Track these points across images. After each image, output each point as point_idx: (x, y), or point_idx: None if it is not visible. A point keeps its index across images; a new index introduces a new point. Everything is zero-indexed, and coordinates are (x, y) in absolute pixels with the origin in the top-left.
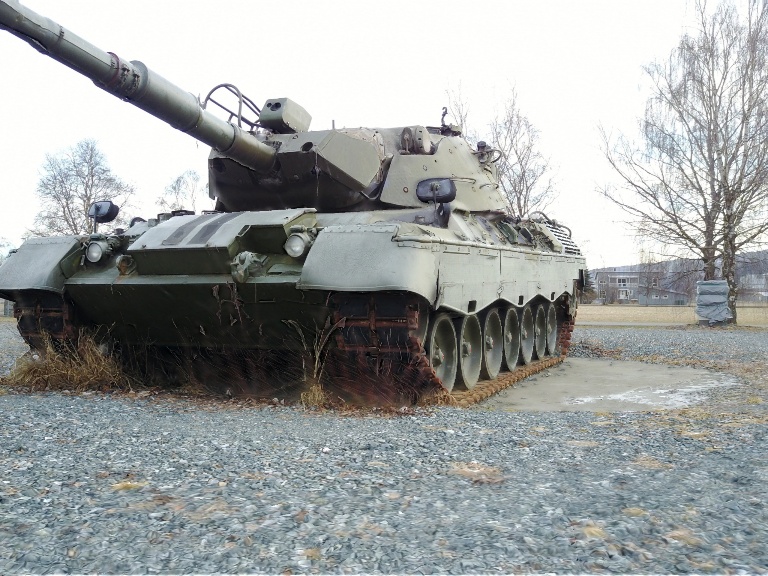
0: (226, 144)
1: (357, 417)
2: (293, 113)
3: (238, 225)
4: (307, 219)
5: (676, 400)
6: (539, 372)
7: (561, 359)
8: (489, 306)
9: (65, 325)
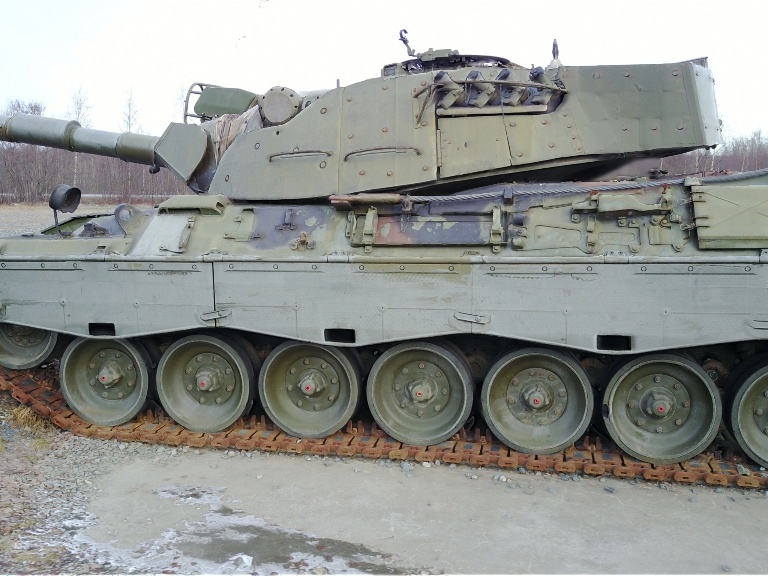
0: (115, 154)
1: None
2: (214, 101)
3: None
4: (81, 224)
5: (192, 562)
6: (535, 472)
7: None
8: None
9: None
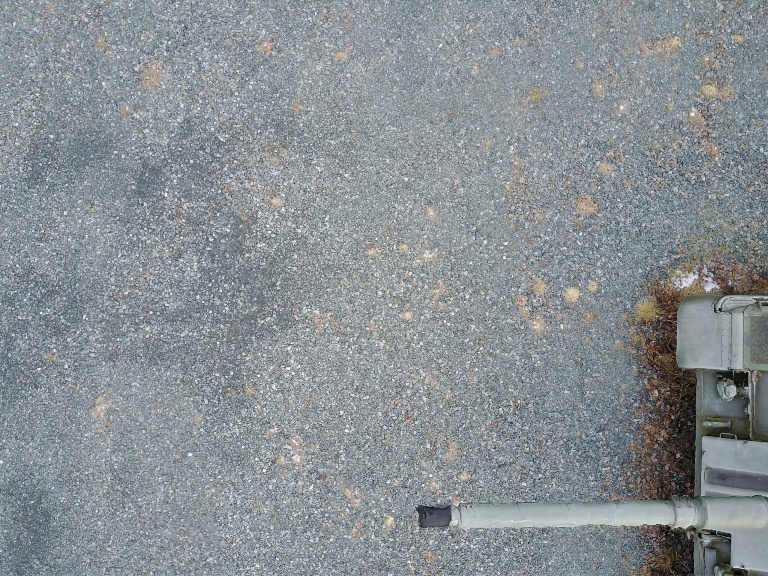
0: None
1: None
2: None
3: None
4: None
5: None
6: None
7: None
8: None
9: None
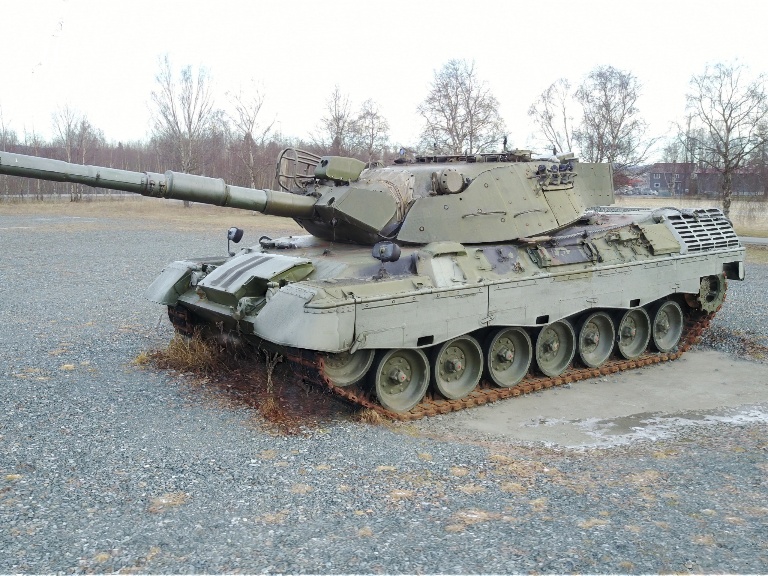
0: (261, 208)
1: (260, 431)
2: (339, 167)
3: (250, 274)
4: (300, 269)
5: (630, 435)
6: (605, 375)
7: (670, 357)
8: (496, 327)
9: (187, 323)
